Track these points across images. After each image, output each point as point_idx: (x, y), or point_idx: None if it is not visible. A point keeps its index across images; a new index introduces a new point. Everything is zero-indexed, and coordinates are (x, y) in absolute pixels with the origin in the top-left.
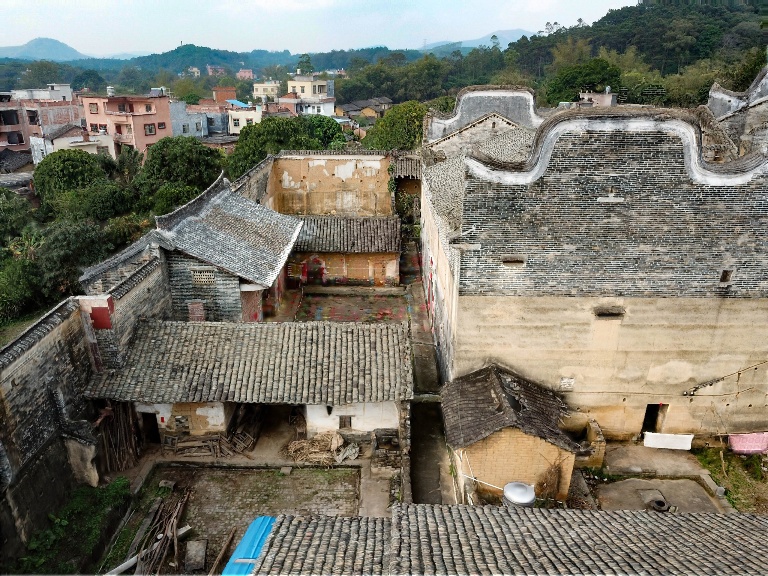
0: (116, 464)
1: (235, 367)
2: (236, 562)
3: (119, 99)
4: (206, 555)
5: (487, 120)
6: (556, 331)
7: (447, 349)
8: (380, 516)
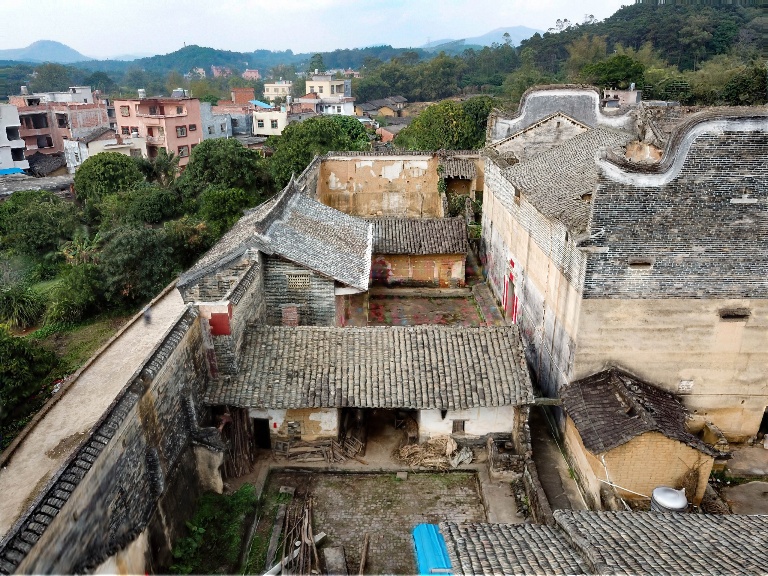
0: (233, 470)
1: (350, 372)
2: (434, 572)
3: (150, 101)
4: (346, 562)
5: (552, 120)
6: (679, 333)
7: (554, 352)
8: (511, 521)
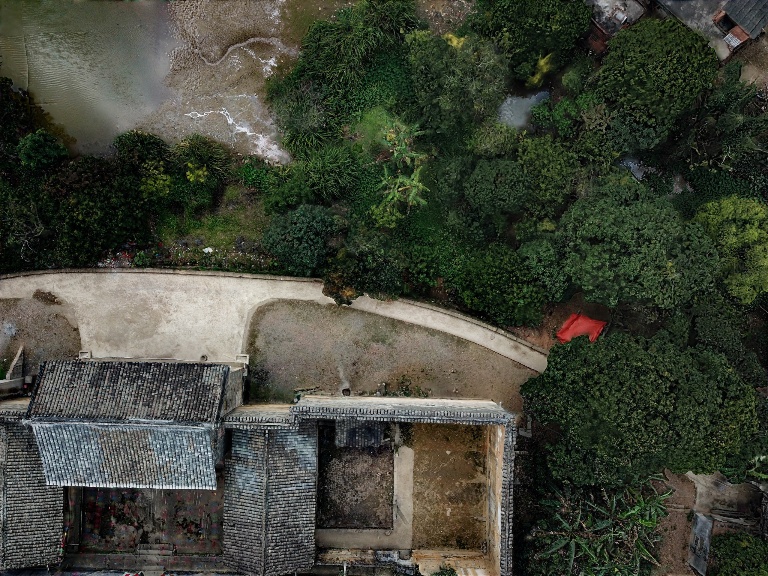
0: None
1: None
2: None
3: None
4: None
5: None
6: None
7: None
8: None
